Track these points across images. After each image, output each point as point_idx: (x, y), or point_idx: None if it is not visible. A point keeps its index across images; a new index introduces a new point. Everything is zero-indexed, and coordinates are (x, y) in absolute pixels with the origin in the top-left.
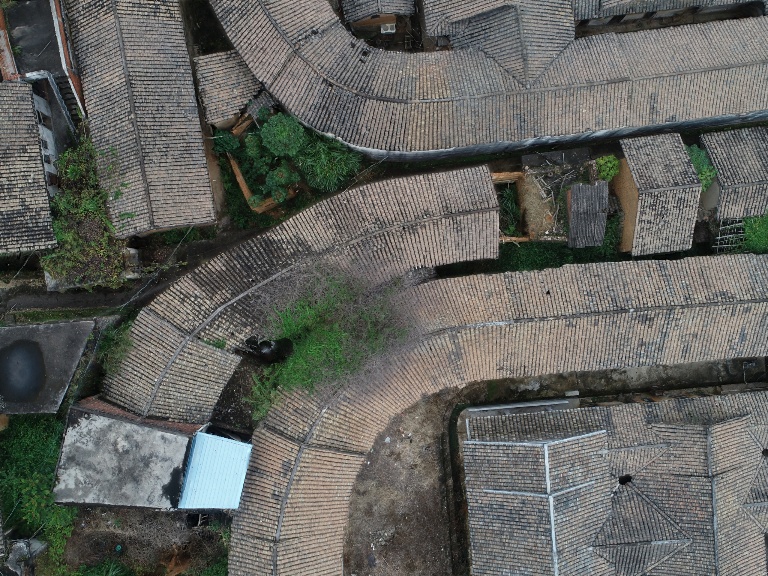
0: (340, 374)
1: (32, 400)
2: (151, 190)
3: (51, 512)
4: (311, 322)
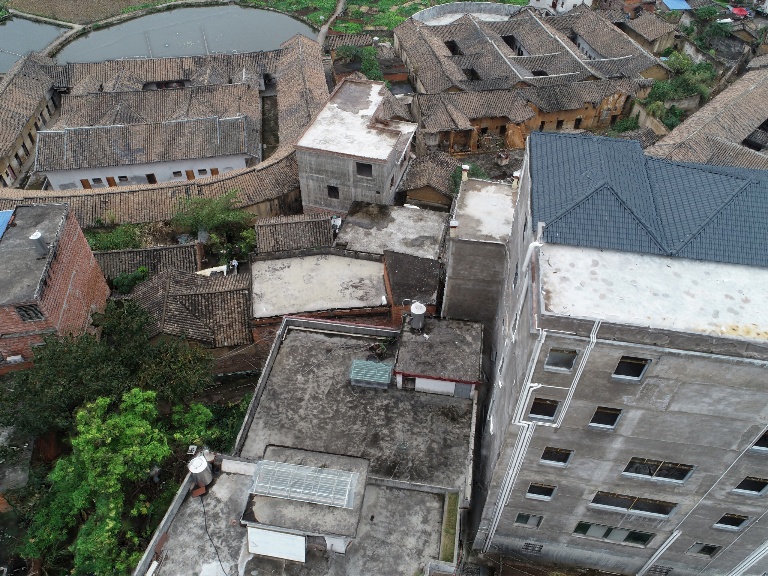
0: None
1: None
2: None
3: None
4: None
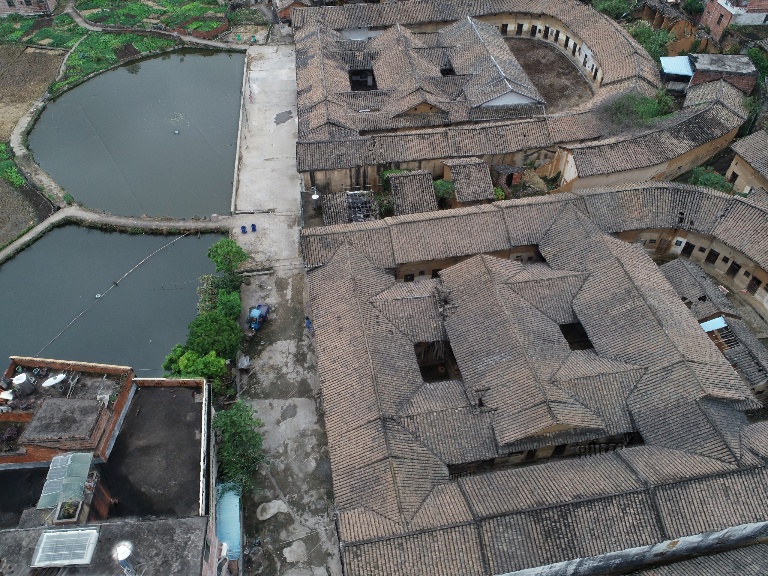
0: None
1: None
2: None
3: None
4: None
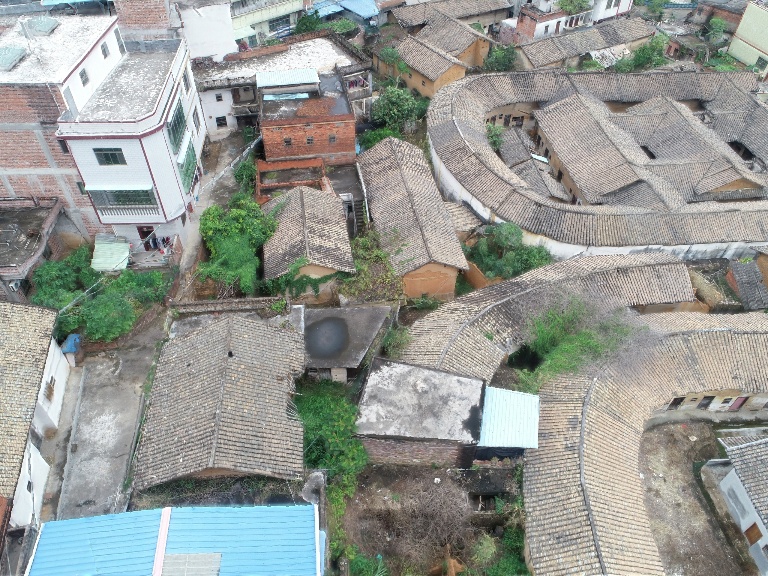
0: (601, 353)
1: (336, 358)
2: (428, 242)
3: (348, 449)
4: (558, 334)
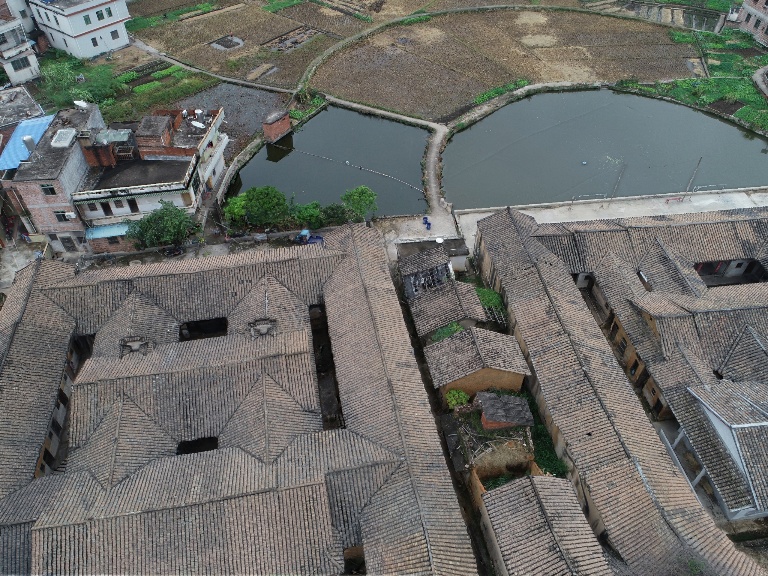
0: None
1: None
2: None
3: None
4: None
